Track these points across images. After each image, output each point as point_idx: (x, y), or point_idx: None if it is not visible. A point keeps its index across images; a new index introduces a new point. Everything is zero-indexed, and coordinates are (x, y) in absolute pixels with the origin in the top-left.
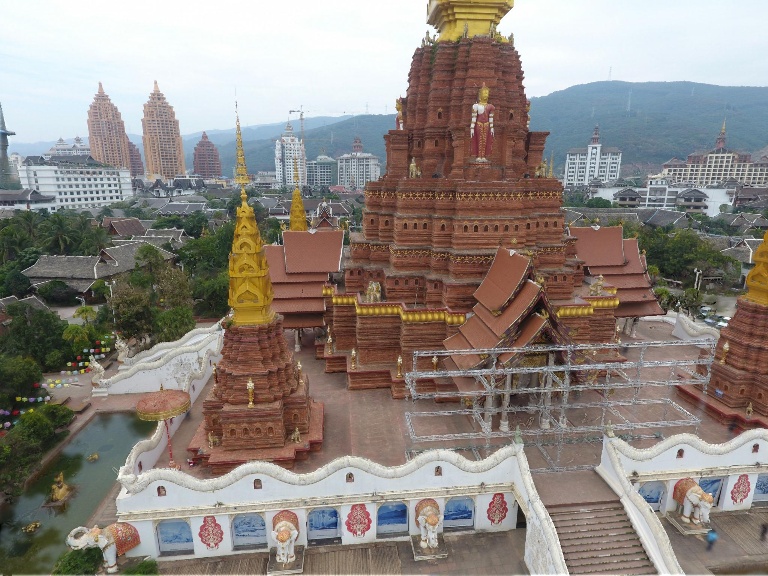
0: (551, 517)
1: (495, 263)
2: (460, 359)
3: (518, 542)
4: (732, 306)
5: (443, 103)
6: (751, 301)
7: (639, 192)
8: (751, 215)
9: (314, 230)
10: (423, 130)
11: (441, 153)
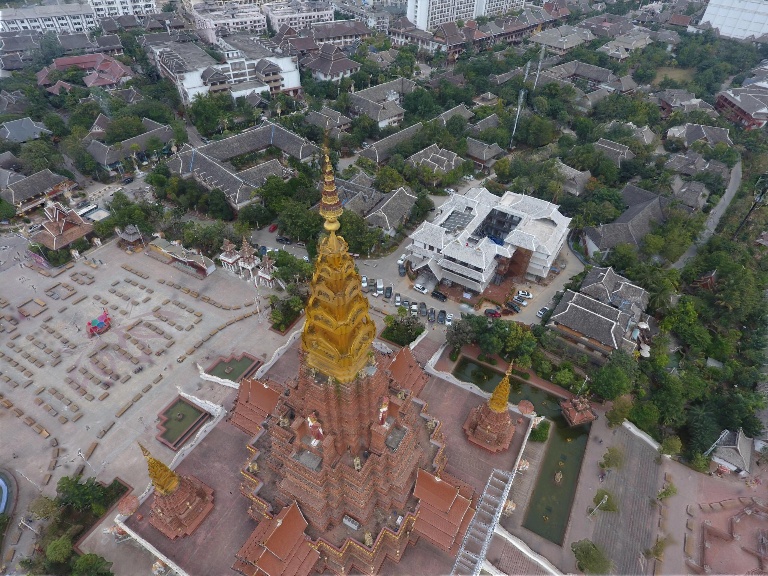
0: (500, 568)
1: (421, 478)
2: (439, 539)
3: (484, 575)
4: (397, 274)
5: (357, 414)
6: (495, 410)
7: (222, 69)
8: (333, 112)
9: (281, 522)
10: (342, 427)
11: (360, 434)
